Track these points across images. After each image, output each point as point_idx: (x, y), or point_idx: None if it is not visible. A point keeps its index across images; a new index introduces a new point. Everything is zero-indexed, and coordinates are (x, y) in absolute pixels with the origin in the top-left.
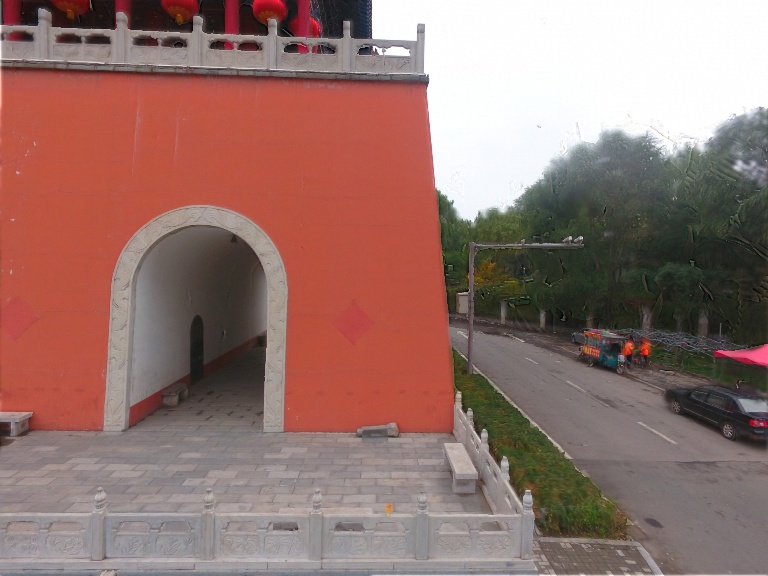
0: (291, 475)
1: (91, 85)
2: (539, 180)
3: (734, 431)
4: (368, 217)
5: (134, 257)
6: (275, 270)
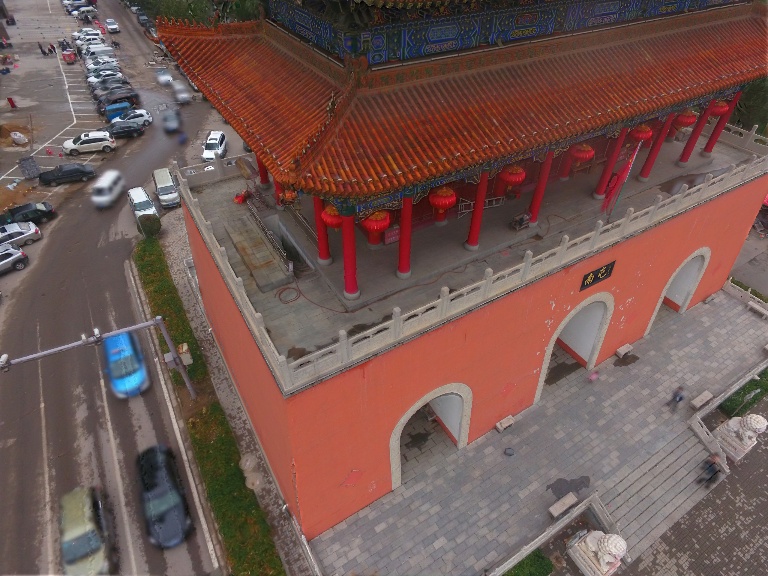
0: None
1: None
2: None
3: (750, 237)
4: None
5: None
6: None
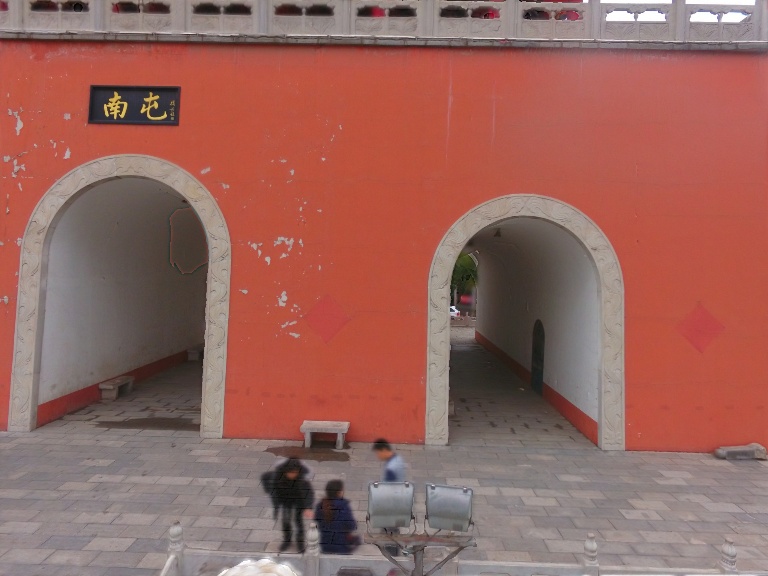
0: (733, 508)
1: (399, 62)
2: None
3: None
4: (712, 206)
5: (452, 252)
6: (610, 267)
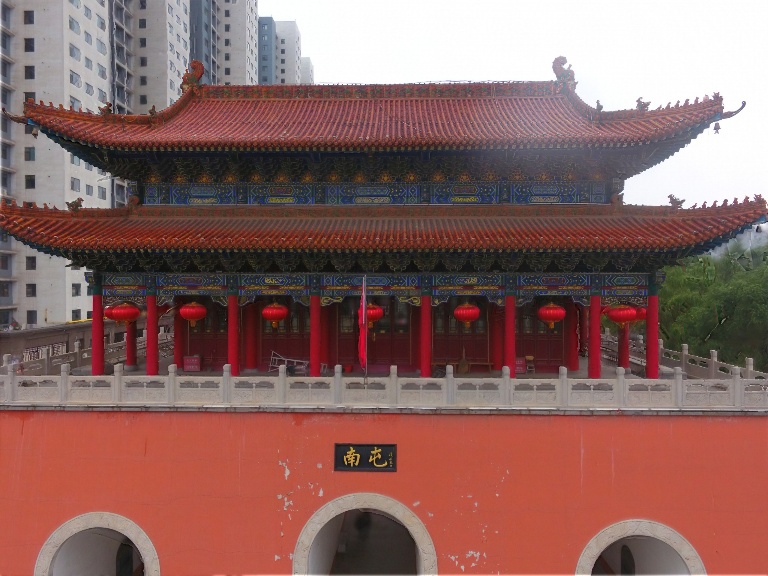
0: None
1: (545, 425)
2: (702, 309)
3: None
4: (766, 526)
5: (590, 561)
6: (699, 572)
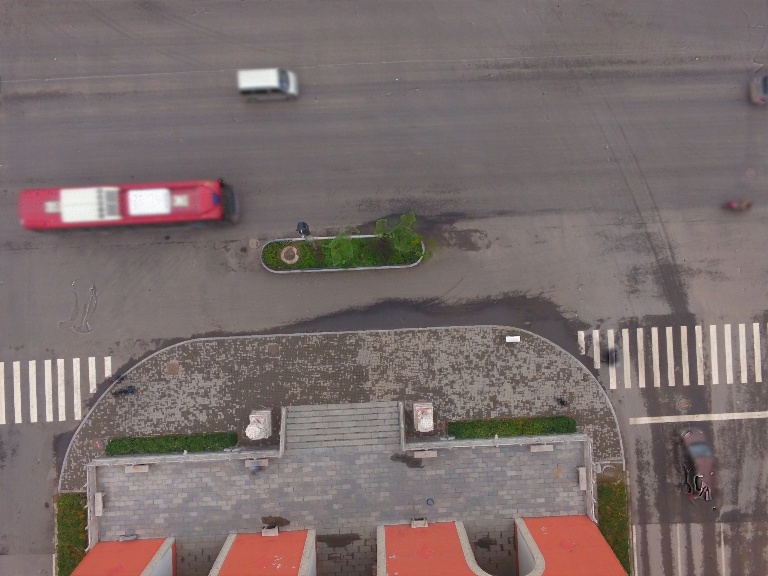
0: (156, 501)
1: None
2: None
3: None
4: None
5: None
6: None
